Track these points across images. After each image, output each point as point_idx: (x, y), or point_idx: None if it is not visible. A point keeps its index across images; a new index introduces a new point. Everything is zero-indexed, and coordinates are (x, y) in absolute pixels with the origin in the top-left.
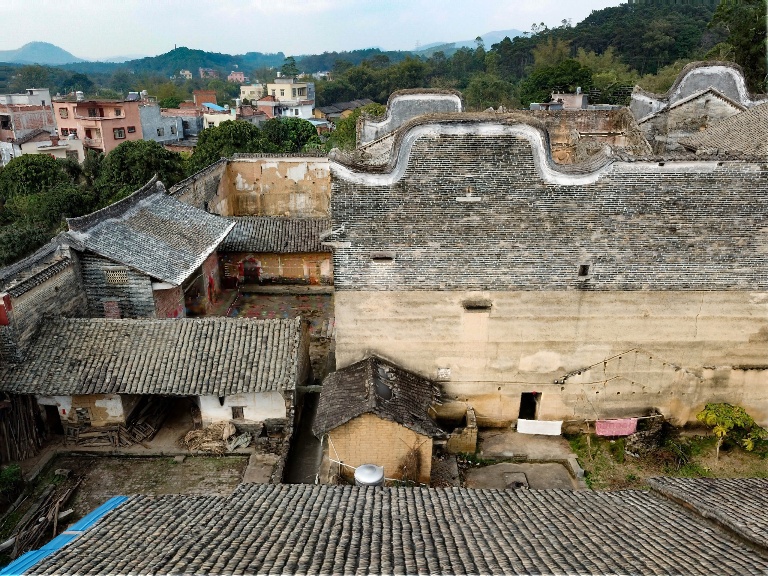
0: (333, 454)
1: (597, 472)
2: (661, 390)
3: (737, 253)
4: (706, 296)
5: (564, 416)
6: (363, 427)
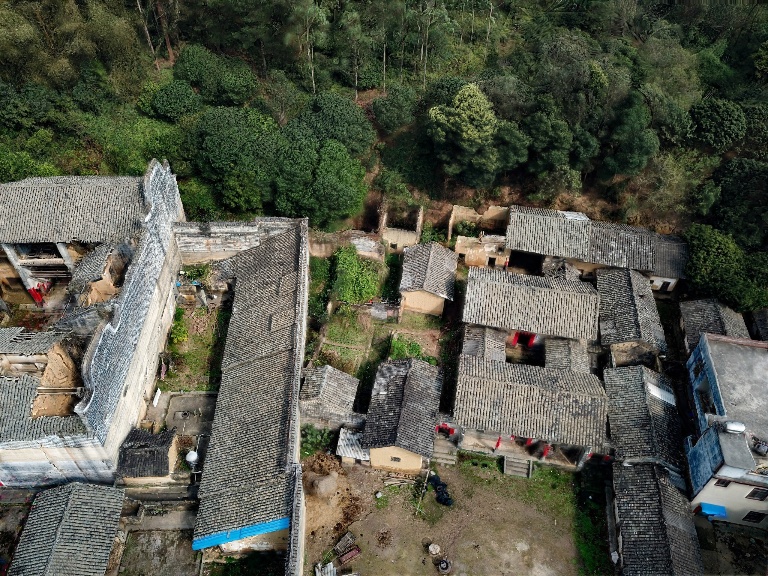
0: (168, 475)
1: (181, 387)
2: (157, 347)
3: (146, 291)
4: (149, 310)
5: (151, 387)
6: (168, 456)
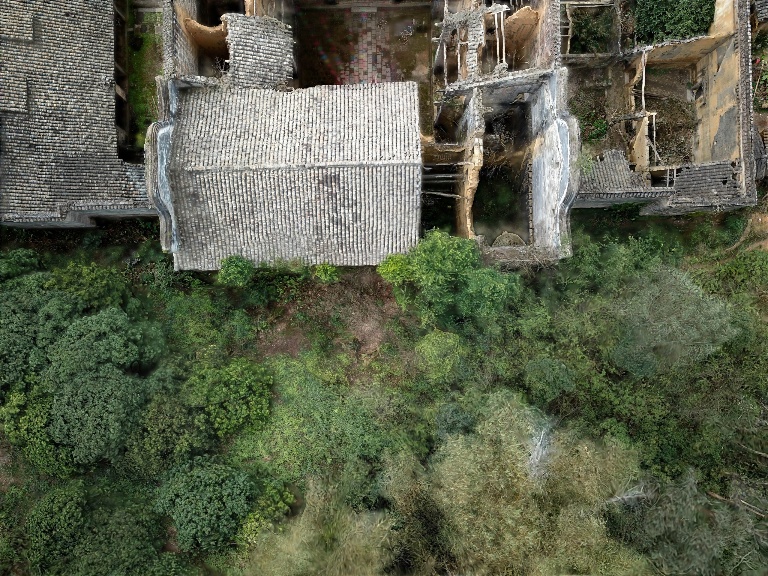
0: None
1: None
2: None
3: None
4: None
5: None
6: None
